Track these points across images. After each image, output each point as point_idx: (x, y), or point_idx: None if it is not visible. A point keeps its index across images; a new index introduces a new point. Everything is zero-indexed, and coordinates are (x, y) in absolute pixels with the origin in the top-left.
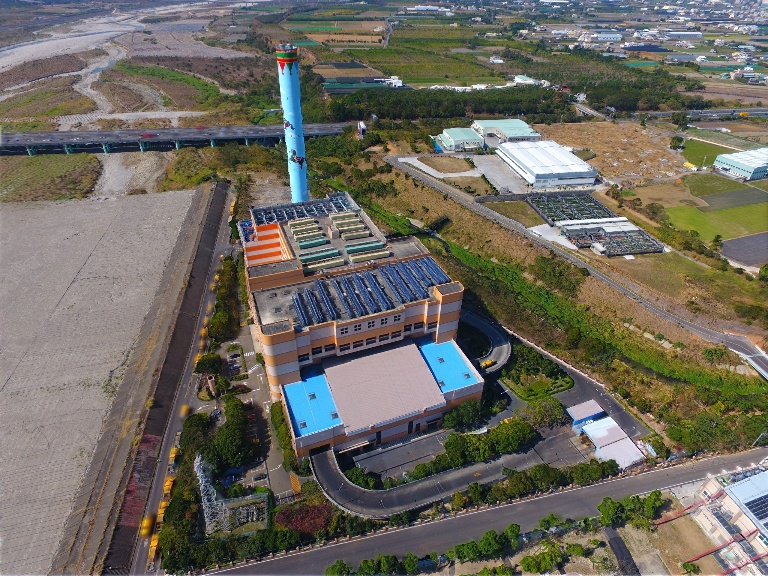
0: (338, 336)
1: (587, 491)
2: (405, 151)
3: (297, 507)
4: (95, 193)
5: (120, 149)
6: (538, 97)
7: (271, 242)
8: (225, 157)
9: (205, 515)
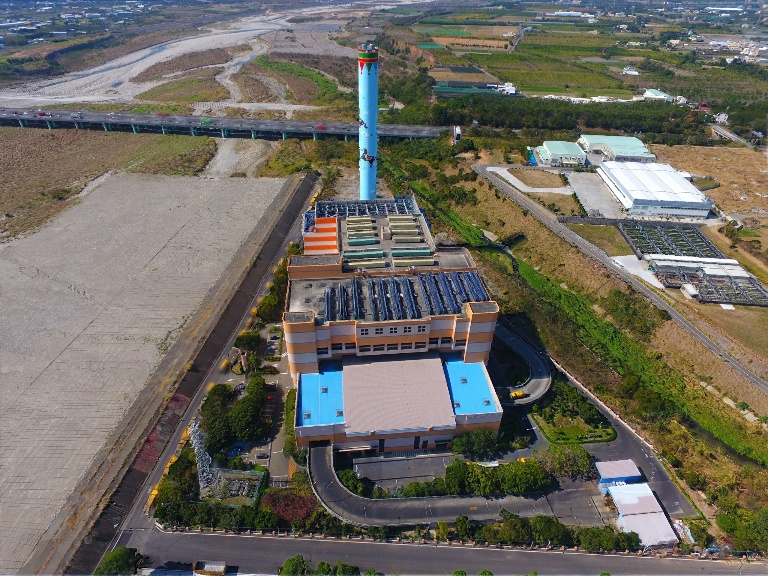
0: (358, 336)
1: (594, 559)
2: (496, 160)
3: (284, 493)
4: (204, 172)
5: (236, 135)
6: (666, 114)
7: (328, 235)
8: (322, 150)
9: (199, 478)
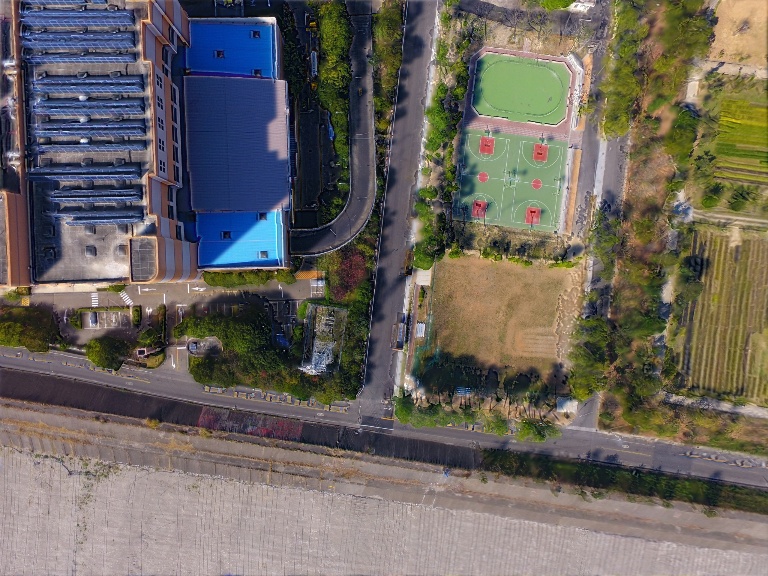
0: (166, 178)
1: None
2: None
3: (337, 278)
4: None
5: None
6: None
7: None
8: None
9: None
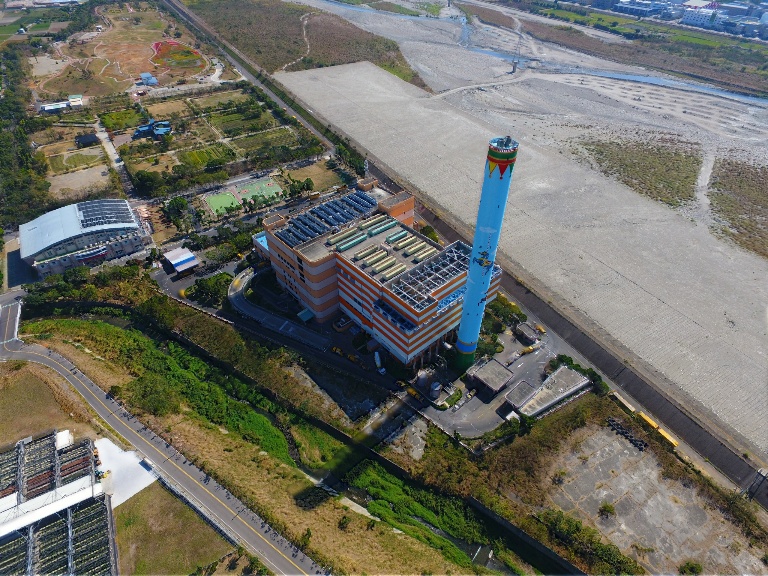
0: None
1: None
2: None
3: None
4: None
5: None
6: None
7: None
8: None
9: None
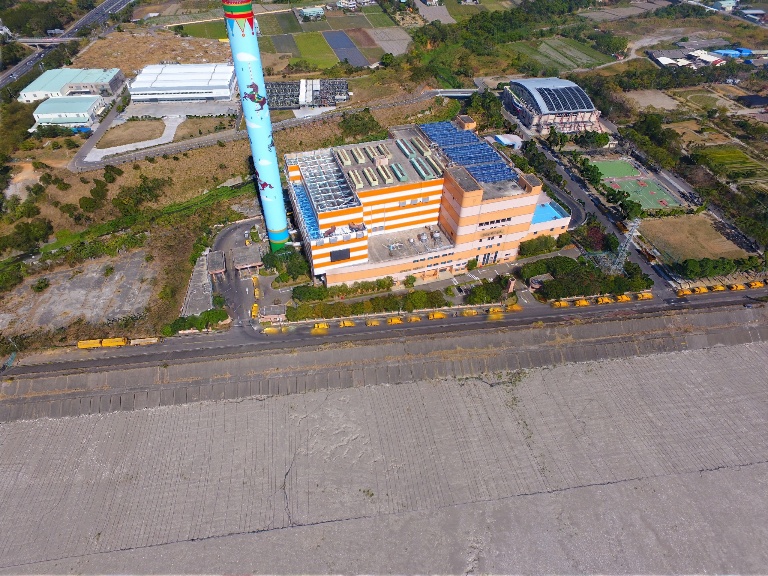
0: None
1: None
2: (62, 154)
3: (591, 238)
4: None
5: None
6: None
7: None
8: None
9: None
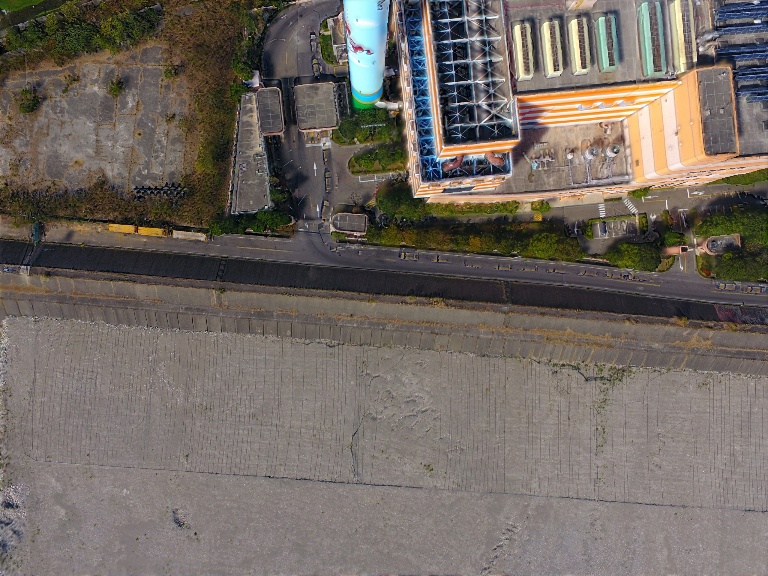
0: None
1: None
2: None
3: None
4: None
5: None
6: None
7: None
8: None
9: None
